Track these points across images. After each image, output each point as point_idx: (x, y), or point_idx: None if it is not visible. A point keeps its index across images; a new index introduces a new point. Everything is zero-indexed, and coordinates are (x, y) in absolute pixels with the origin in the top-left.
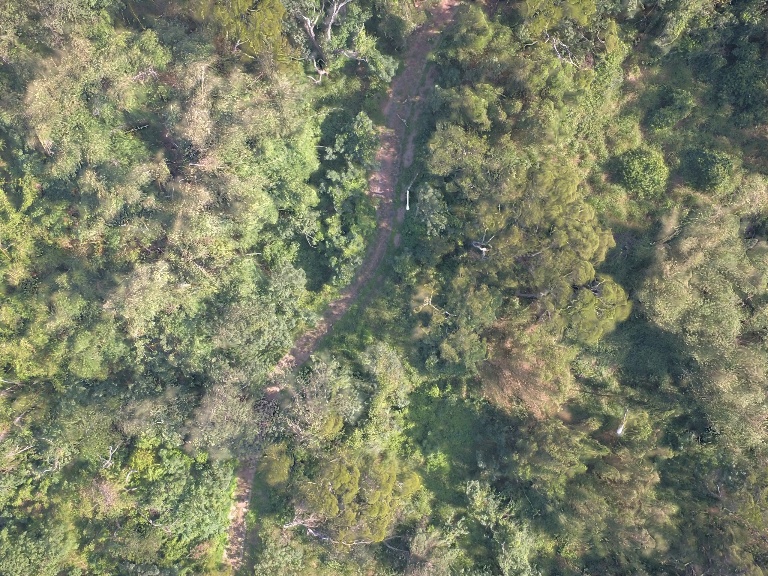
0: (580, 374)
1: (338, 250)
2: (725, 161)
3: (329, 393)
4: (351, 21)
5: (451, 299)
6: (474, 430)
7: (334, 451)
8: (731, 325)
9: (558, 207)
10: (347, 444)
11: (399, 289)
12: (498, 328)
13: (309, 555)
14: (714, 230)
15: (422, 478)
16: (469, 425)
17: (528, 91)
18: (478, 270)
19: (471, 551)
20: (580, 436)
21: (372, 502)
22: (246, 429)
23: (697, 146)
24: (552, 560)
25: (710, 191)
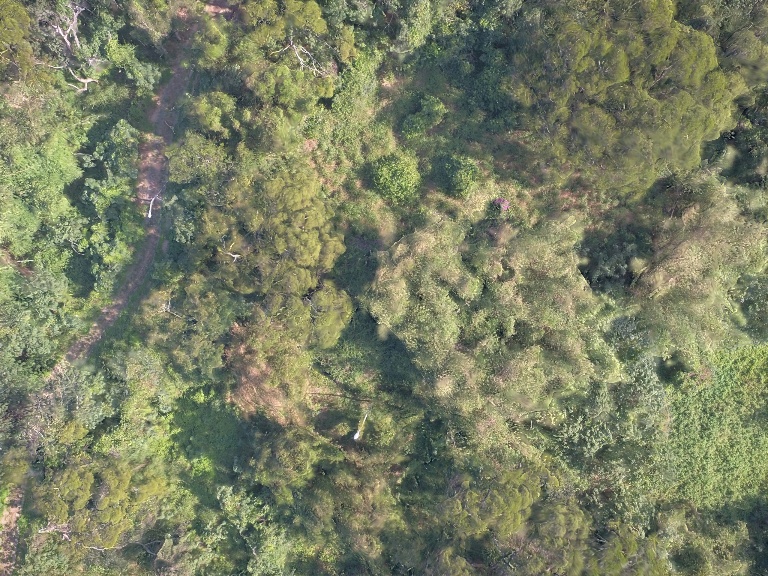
0: (336, 379)
1: (101, 257)
2: (468, 167)
3: (81, 399)
4: (102, 30)
5: (184, 306)
6: (238, 435)
7: (83, 457)
8: (444, 331)
9: (282, 214)
10: (95, 450)
11: (162, 295)
12: (238, 335)
13: (76, 560)
14: (424, 237)
15: (187, 483)
16: (234, 430)
17: (258, 99)
18: (217, 277)
19: (232, 556)
20: (315, 442)
21: (100, 508)
22: (14, 435)
23: (448, 152)
24: (312, 564)
25: (459, 197)
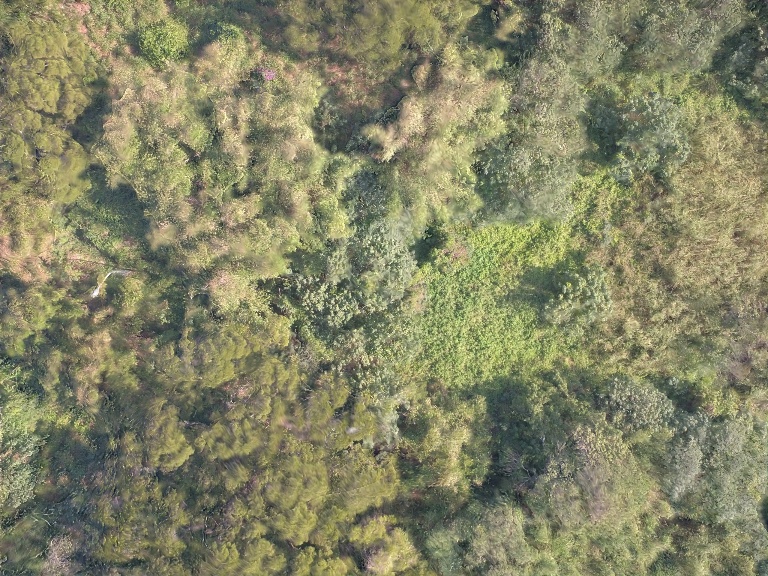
0: (97, 245)
1: None
2: (228, 32)
3: None
4: None
5: None
6: None
7: None
8: (169, 179)
9: (20, 60)
10: None
11: None
12: None
13: None
14: (150, 82)
15: None
16: None
17: None
18: None
19: None
20: (53, 296)
21: None
22: None
23: (217, 20)
24: (66, 431)
25: (223, 65)
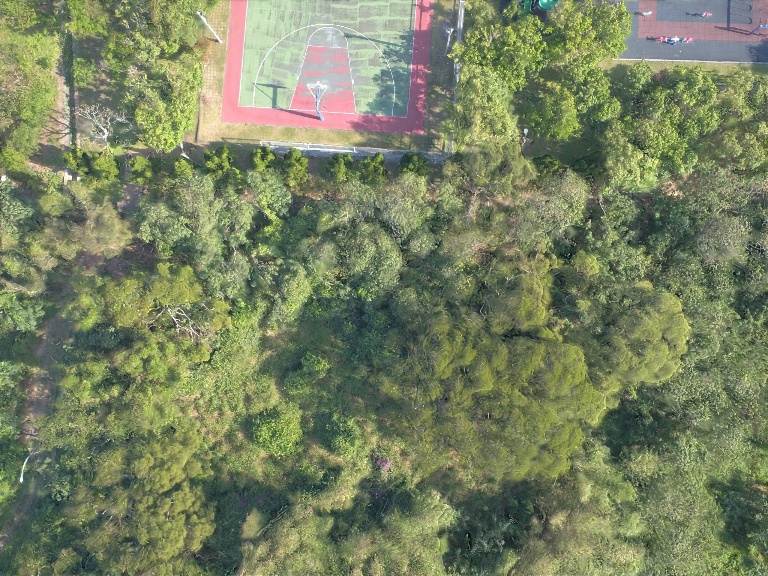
0: None
1: None
2: (347, 433)
3: None
4: None
5: None
6: None
7: None
8: None
9: (147, 500)
10: None
11: (45, 538)
12: None
13: None
14: (284, 541)
15: None
16: None
17: None
18: None
19: None
20: None
21: None
22: None
23: (331, 409)
24: None
25: None
